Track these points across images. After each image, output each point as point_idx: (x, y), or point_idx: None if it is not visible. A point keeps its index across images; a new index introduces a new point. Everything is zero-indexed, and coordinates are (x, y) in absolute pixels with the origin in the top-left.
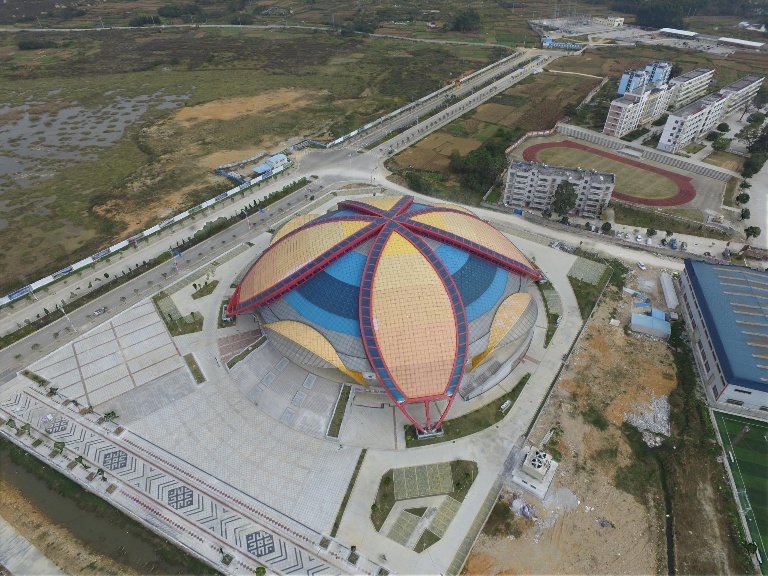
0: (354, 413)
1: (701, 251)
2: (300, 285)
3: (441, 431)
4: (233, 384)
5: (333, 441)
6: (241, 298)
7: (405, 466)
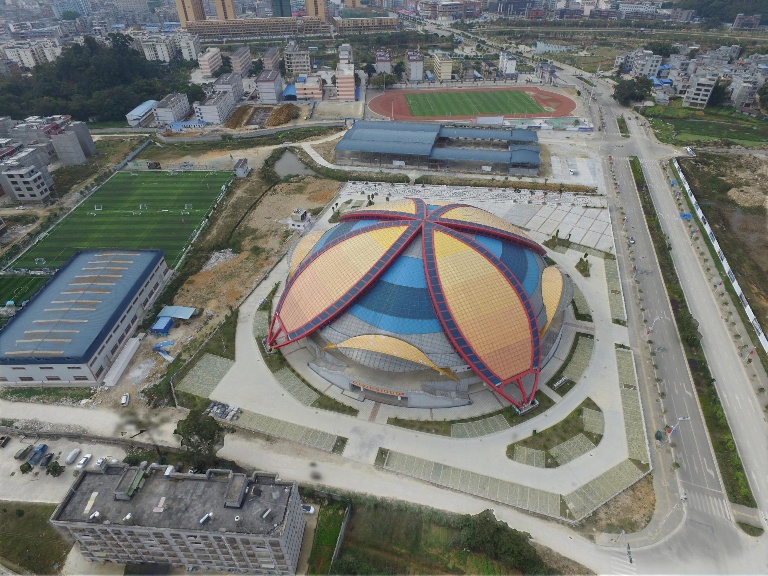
0: None
1: (0, 454)
2: None
3: None
4: None
5: None
6: None
7: None
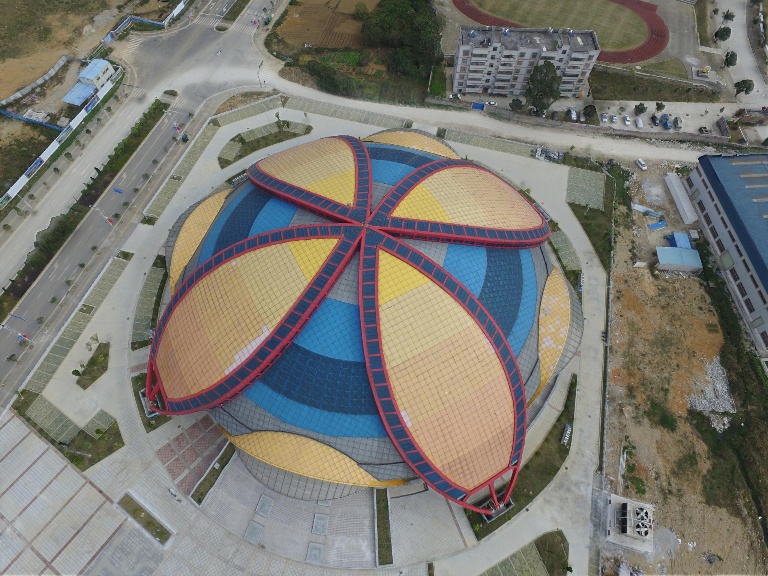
0: (396, 512)
1: (695, 125)
2: (264, 373)
3: (511, 505)
4: (214, 525)
5: (387, 567)
6: (168, 391)
7: (486, 569)
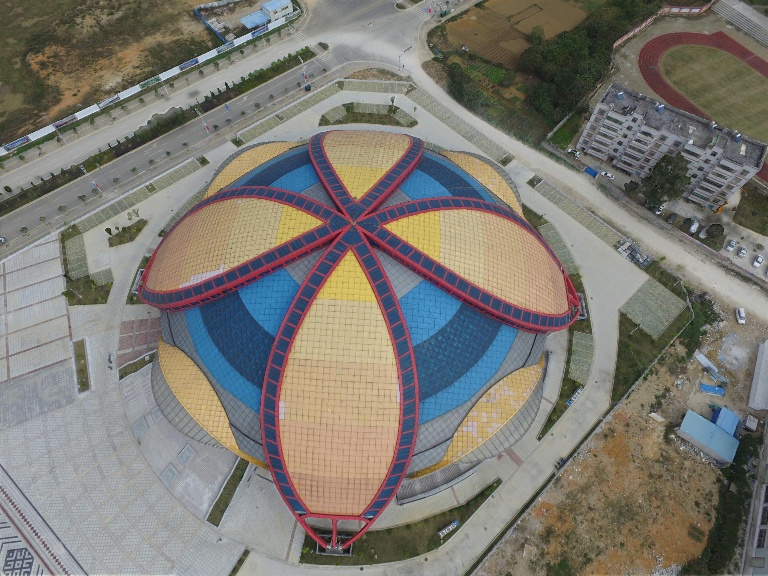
0: (252, 488)
1: None
2: (205, 303)
3: (348, 553)
4: (120, 402)
5: (213, 527)
6: (148, 279)
7: None
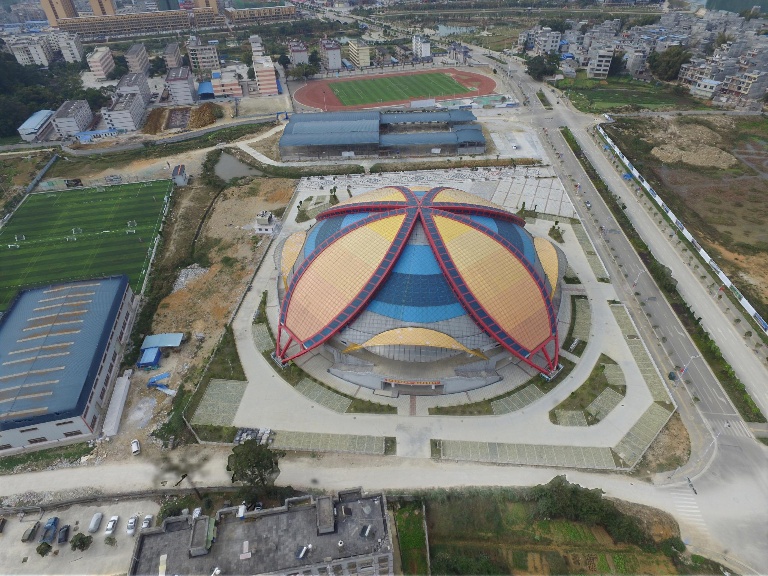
0: None
1: (0, 541)
2: None
3: None
4: None
5: None
6: None
7: None
